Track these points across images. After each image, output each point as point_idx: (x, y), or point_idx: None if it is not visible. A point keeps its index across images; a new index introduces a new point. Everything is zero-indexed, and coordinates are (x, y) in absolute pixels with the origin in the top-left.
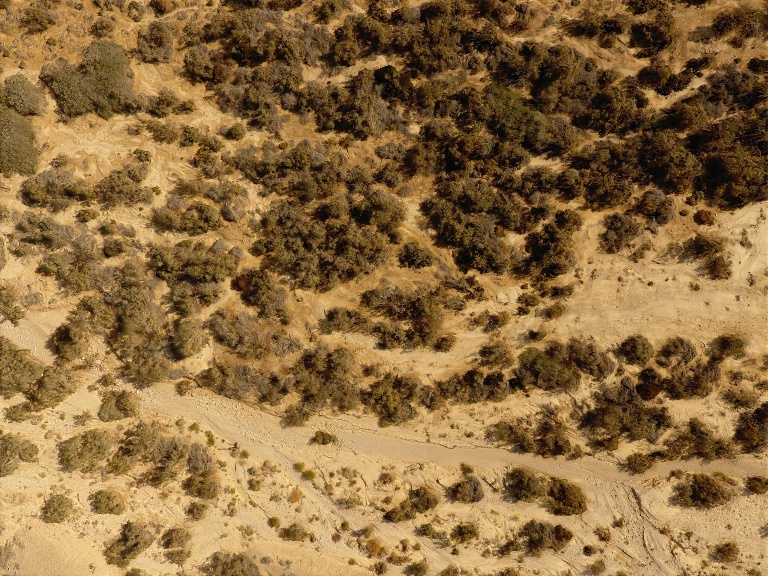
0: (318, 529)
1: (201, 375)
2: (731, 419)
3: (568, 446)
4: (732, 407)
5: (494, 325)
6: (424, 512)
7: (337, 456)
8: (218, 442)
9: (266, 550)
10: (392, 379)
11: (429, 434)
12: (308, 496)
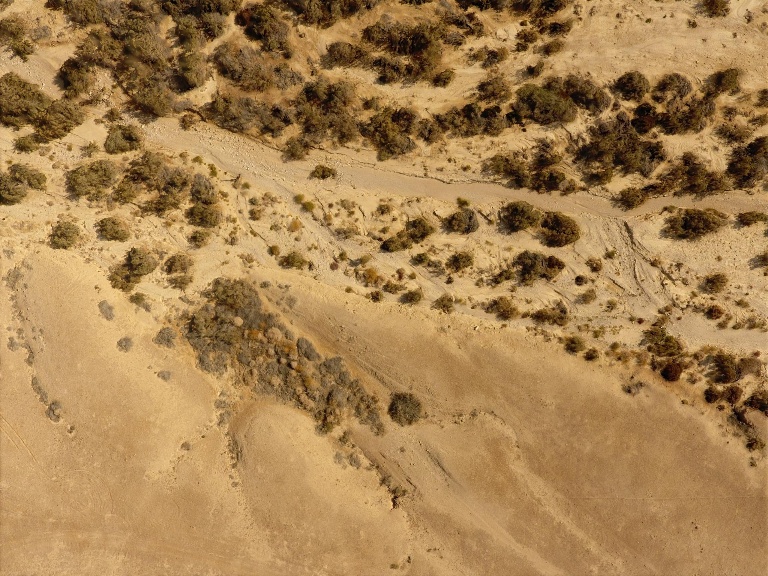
0: (317, 258)
1: (205, 107)
2: (724, 154)
3: (563, 176)
4: (726, 142)
5: (493, 59)
6: (420, 242)
7: (336, 189)
8: (221, 174)
9: (266, 276)
10: (391, 111)
11: (427, 168)
12: (307, 226)
